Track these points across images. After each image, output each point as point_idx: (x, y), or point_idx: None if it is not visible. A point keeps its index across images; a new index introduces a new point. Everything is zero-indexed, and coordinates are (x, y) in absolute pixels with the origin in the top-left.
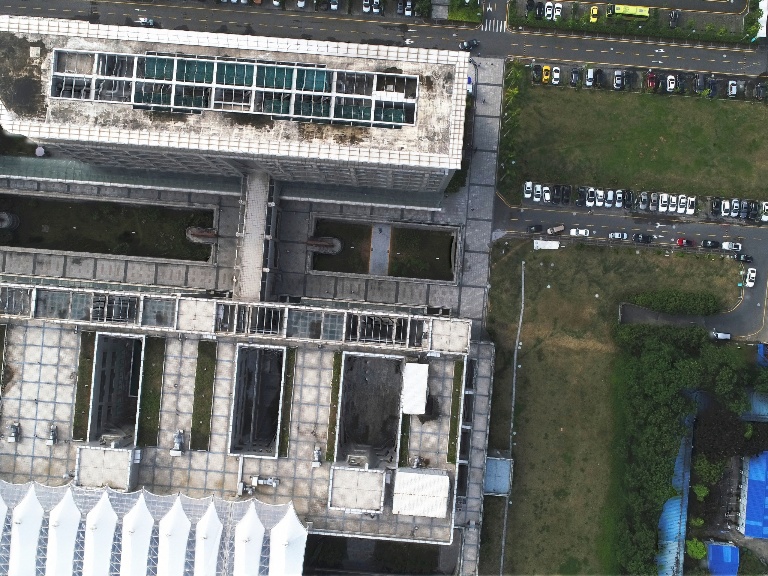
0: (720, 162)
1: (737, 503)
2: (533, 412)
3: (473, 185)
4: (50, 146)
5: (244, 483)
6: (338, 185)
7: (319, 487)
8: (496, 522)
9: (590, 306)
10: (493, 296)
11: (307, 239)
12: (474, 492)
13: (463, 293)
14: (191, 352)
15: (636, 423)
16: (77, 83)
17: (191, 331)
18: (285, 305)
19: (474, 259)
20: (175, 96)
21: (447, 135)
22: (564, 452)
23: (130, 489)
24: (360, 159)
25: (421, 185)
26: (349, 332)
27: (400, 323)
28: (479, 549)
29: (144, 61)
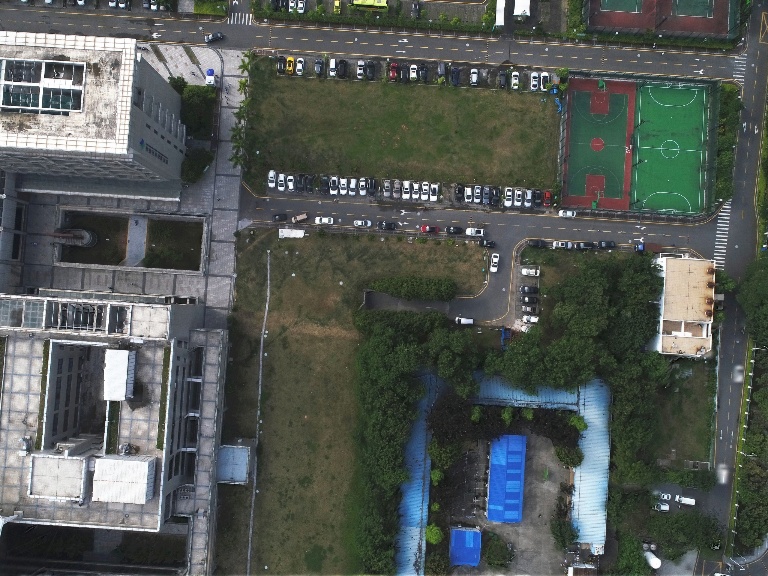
0: (461, 149)
1: (485, 488)
2: (278, 400)
3: (219, 175)
4: None
5: None
6: (72, 176)
7: None
8: (243, 511)
9: (334, 293)
10: (239, 285)
11: (53, 231)
12: (203, 480)
13: (210, 283)
14: None
15: (366, 408)
16: None
17: None
18: None
19: (220, 249)
20: None
21: (114, 121)
22: (308, 439)
23: None
24: (28, 145)
25: (139, 174)
26: (50, 320)
27: (101, 310)
28: (207, 537)
29: None
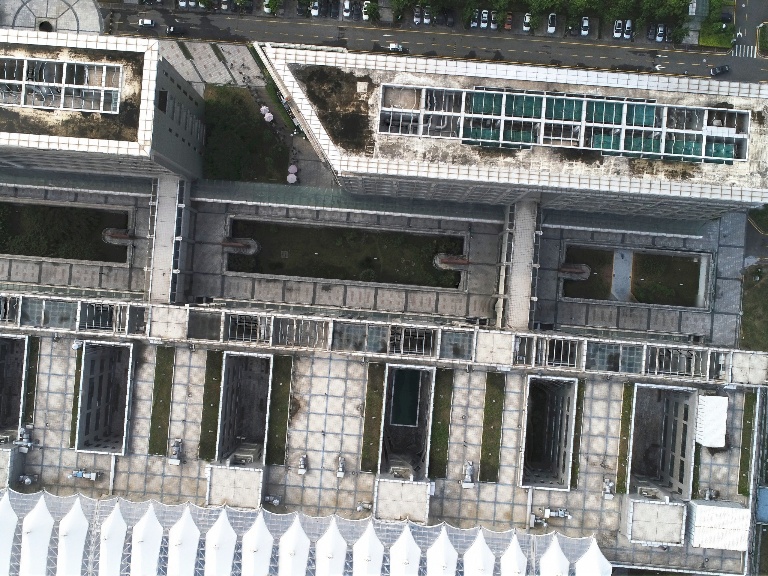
0: None
1: None
2: None
3: (725, 212)
4: (350, 178)
5: None
6: (603, 213)
7: (609, 519)
8: None
9: None
10: (745, 323)
11: (559, 266)
12: None
13: (715, 320)
14: (479, 383)
15: None
16: (404, 118)
17: (489, 364)
18: None
19: (726, 286)
20: (504, 131)
21: None
22: None
23: (430, 522)
24: (691, 195)
25: (701, 215)
26: (647, 365)
27: (698, 355)
28: None
29: (473, 96)
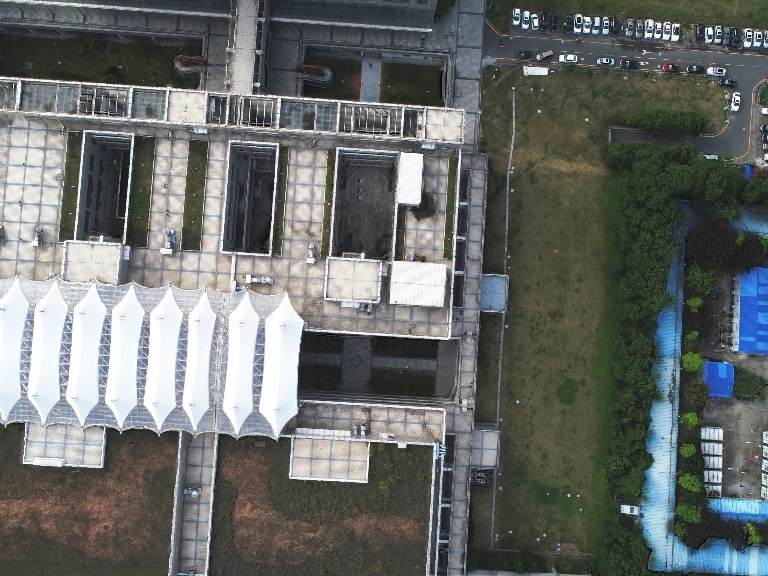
0: None
1: (730, 323)
2: (527, 234)
3: (462, 13)
4: None
5: (237, 283)
6: (328, 3)
7: (314, 286)
8: (492, 346)
9: (580, 130)
10: (484, 122)
11: (297, 66)
12: (470, 303)
13: None
14: (182, 152)
15: (629, 233)
16: None
17: (182, 122)
18: (278, 96)
19: (465, 86)
20: None
21: None
22: (558, 273)
23: (119, 283)
24: None
25: None
26: (343, 123)
27: (394, 114)
28: None
29: None
